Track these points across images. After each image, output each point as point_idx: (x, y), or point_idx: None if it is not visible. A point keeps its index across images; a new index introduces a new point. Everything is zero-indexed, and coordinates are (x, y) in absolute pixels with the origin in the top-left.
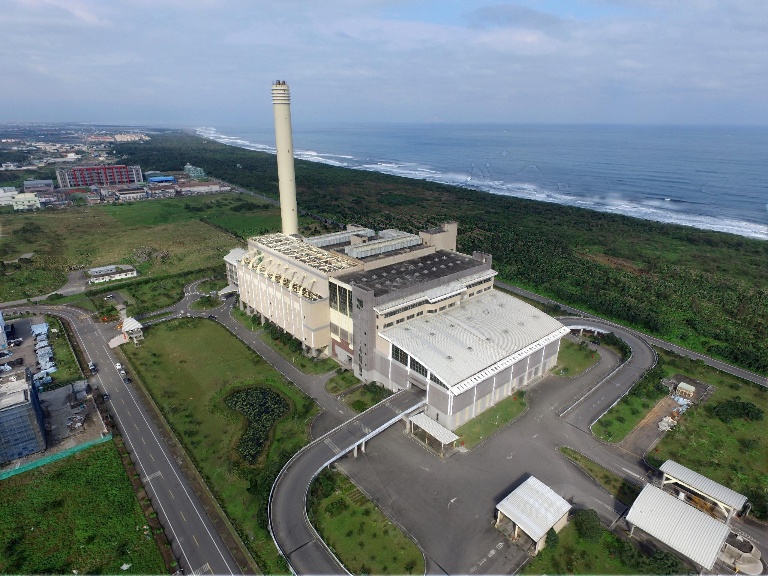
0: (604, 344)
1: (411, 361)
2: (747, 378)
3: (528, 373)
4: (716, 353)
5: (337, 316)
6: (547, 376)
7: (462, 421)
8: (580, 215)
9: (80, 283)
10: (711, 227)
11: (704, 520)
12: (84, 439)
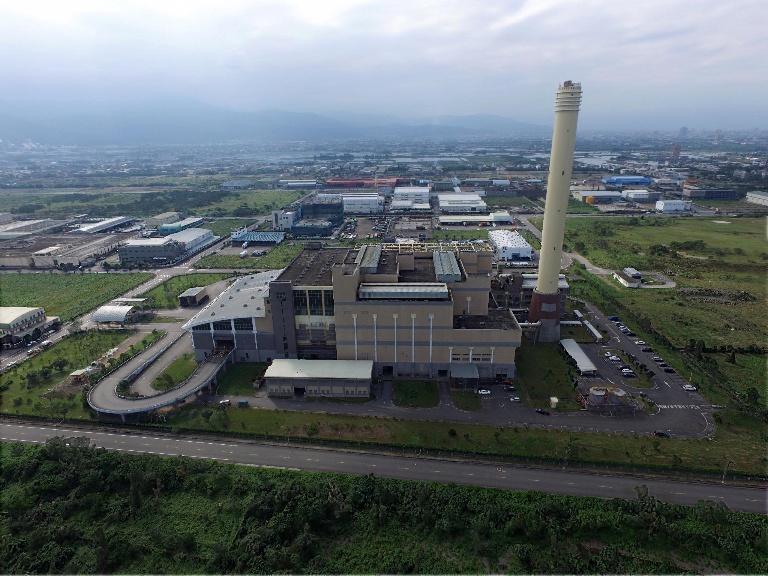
0: None
1: None
2: None
3: None
4: None
5: None
6: None
7: None
8: None
9: None
10: None
11: (122, 299)
12: None
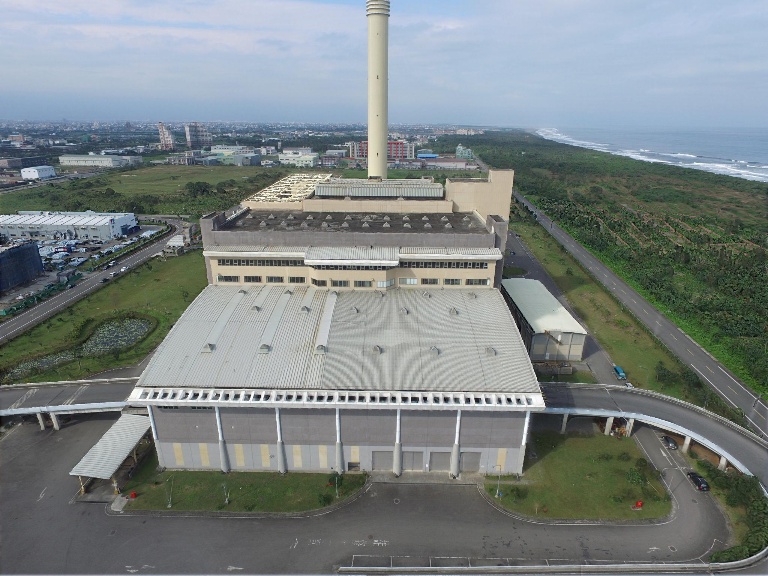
0: (721, 496)
1: None
2: None
3: (409, 453)
4: None
5: None
6: (464, 482)
7: (195, 464)
8: None
9: (230, 212)
10: None
11: None
12: None
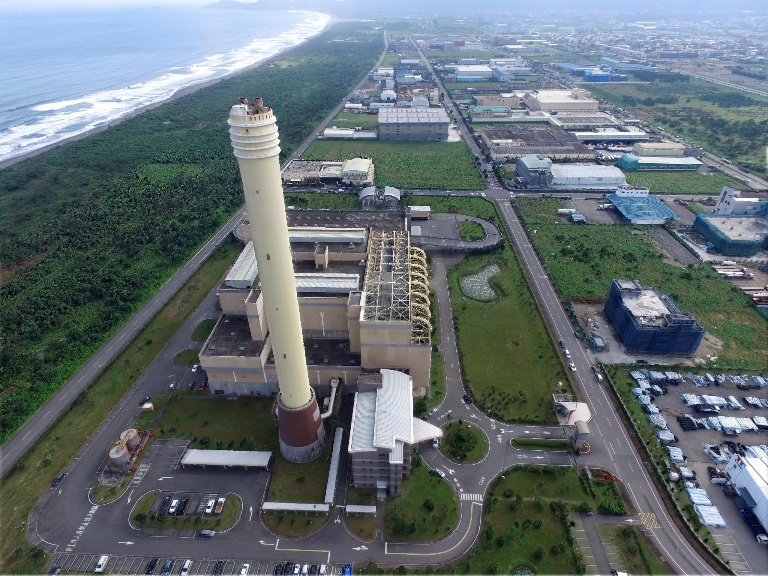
0: None
1: None
2: None
3: None
4: (233, 210)
5: None
6: None
7: None
8: None
9: None
10: None
11: (388, 188)
12: (584, 309)
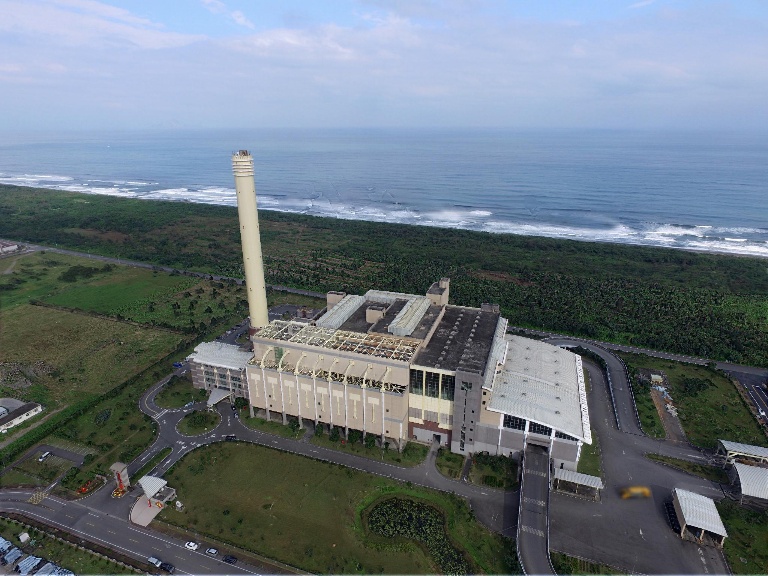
0: None
1: (530, 425)
2: (668, 358)
3: None
4: (638, 343)
5: (421, 400)
6: None
7: None
8: (434, 234)
9: None
10: (529, 233)
11: None
12: None
